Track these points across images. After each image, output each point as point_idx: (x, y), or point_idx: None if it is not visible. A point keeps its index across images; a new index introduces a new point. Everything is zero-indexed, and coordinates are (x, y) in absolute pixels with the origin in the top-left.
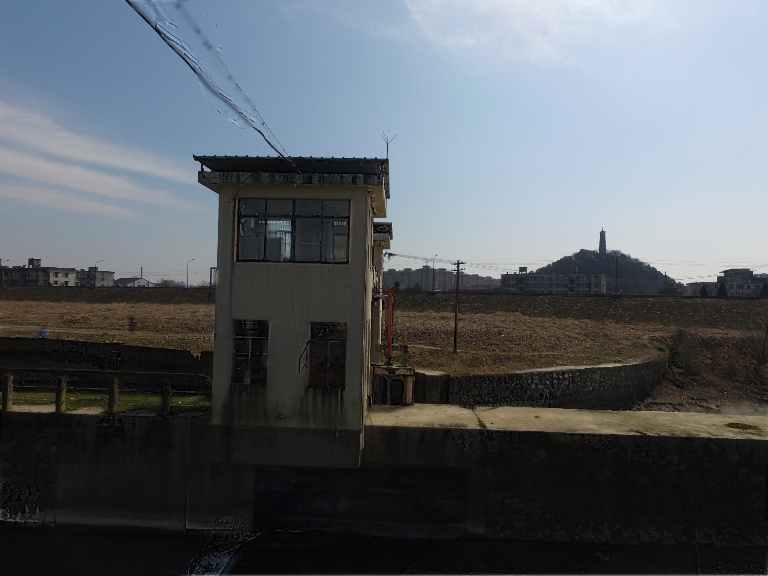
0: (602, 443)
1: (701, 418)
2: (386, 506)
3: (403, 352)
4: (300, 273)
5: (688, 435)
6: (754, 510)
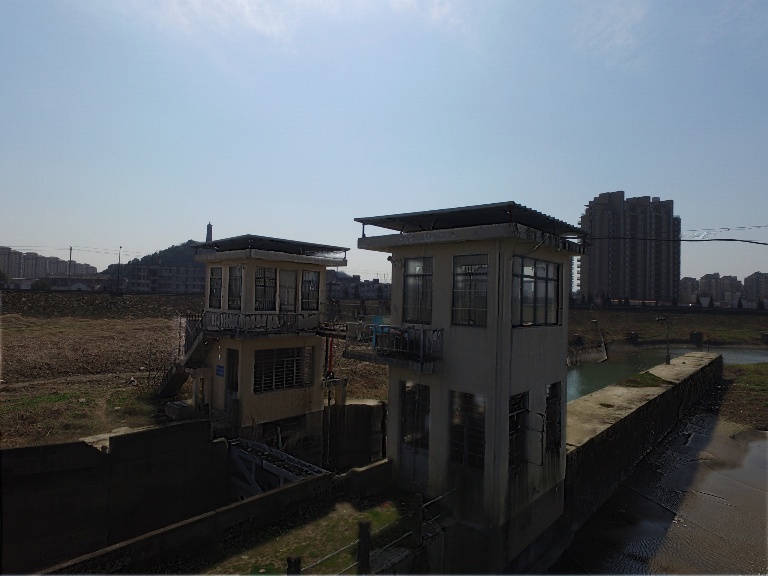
0: (605, 436)
1: (585, 404)
2: (548, 539)
3: (343, 386)
4: (544, 337)
5: (618, 418)
6: (630, 453)
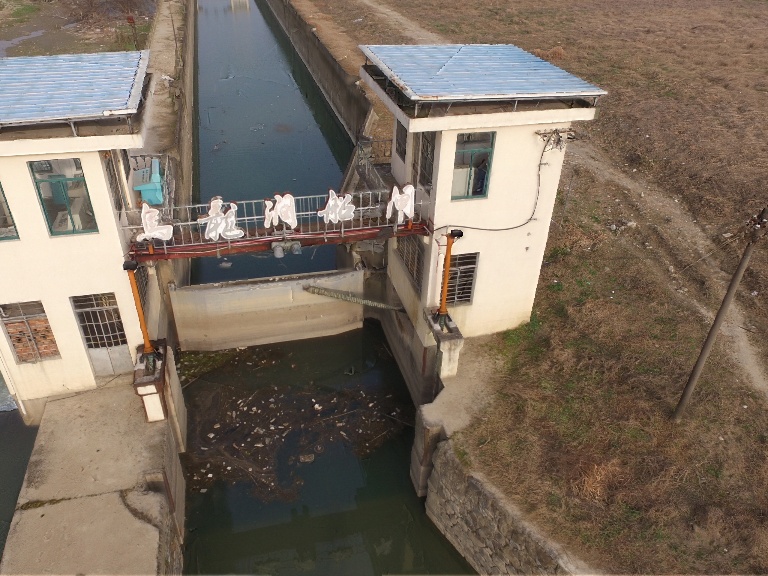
0: None
1: None
2: None
3: None
4: None
5: None
6: None
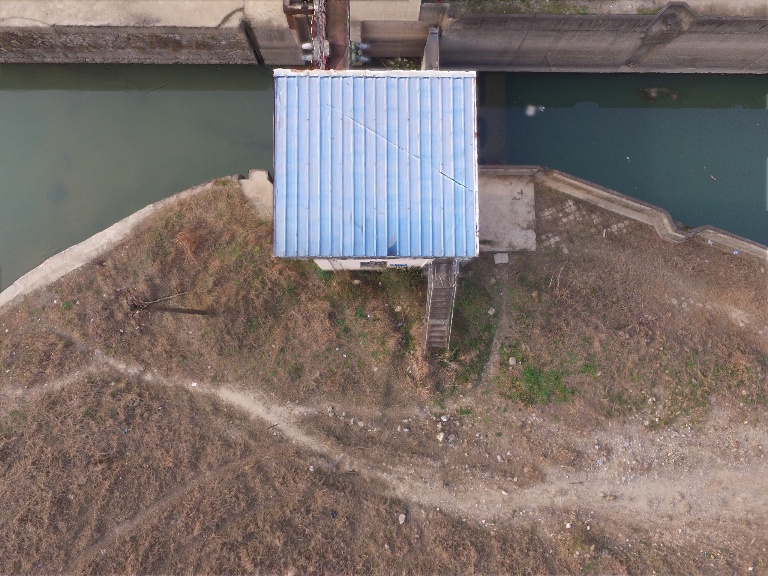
0: None
1: (72, 7)
2: None
3: None
4: None
5: None
6: None
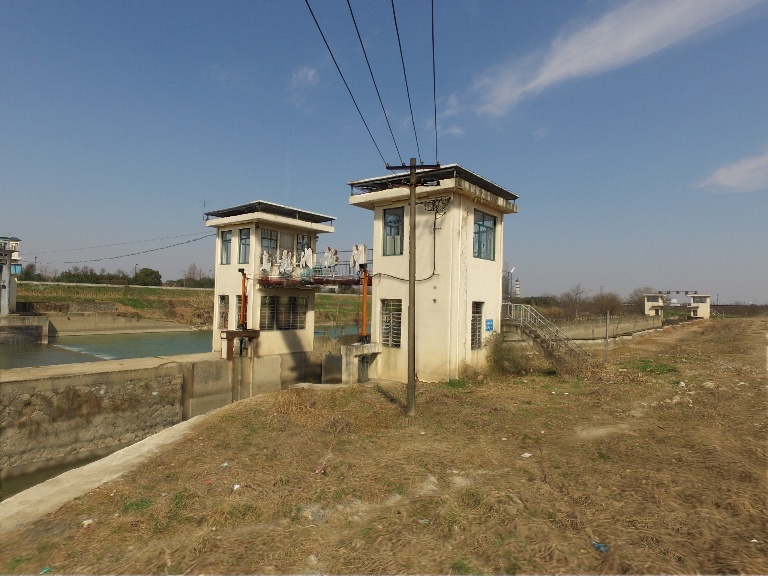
0: None
1: None
2: None
3: None
4: None
5: None
6: None
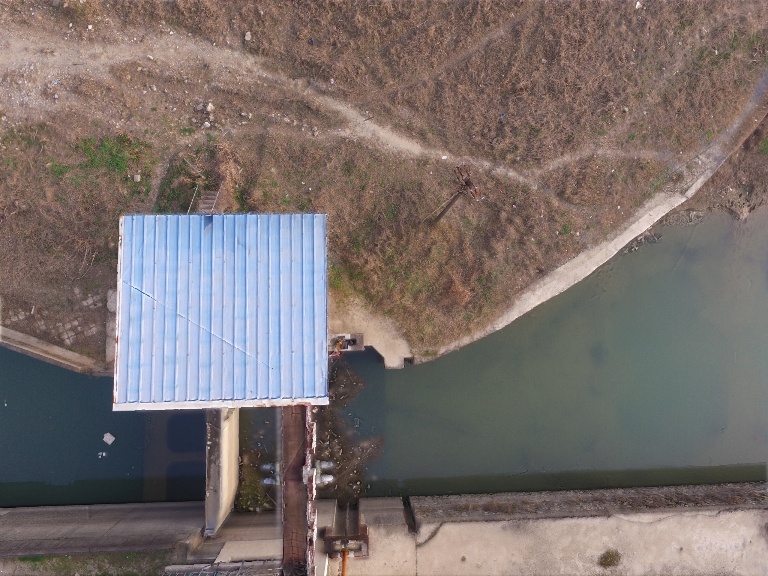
0: None
1: (593, 538)
2: None
3: None
4: None
5: None
6: None
